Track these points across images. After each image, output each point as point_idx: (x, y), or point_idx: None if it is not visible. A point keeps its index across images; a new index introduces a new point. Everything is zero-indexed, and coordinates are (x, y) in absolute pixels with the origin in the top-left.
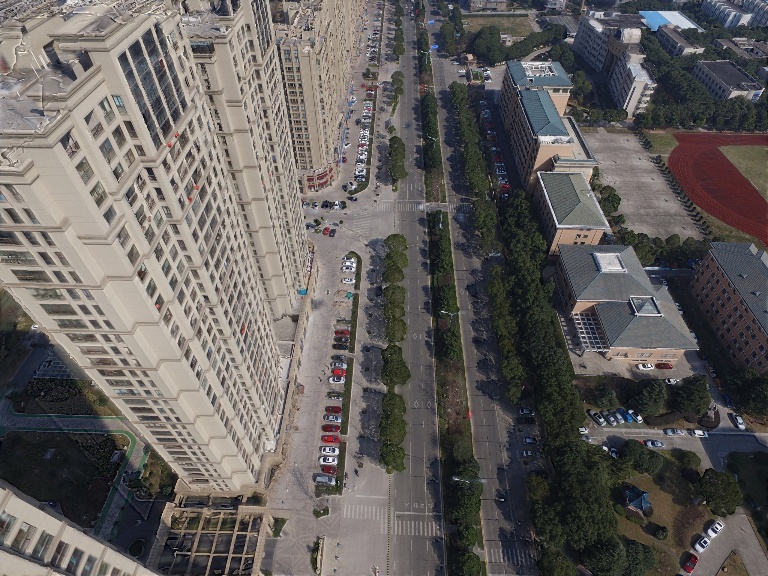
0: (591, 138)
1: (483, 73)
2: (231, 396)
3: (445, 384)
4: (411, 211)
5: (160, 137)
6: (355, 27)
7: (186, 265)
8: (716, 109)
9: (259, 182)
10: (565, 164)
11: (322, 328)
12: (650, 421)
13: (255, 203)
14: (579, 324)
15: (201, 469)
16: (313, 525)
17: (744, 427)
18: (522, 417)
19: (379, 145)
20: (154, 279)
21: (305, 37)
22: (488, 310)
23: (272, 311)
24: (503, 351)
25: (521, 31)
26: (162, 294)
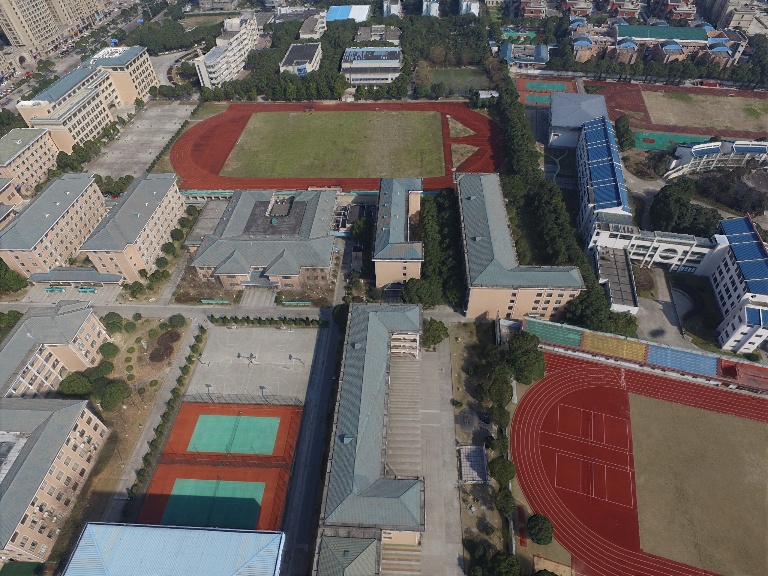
0: (158, 109)
1: None
2: None
3: None
4: None
5: None
6: None
7: None
8: (267, 82)
9: None
10: (36, 122)
11: None
12: None
13: None
14: None
15: None
16: None
17: None
18: None
19: None
20: None
21: None
22: None
23: None
24: None
25: None
26: None
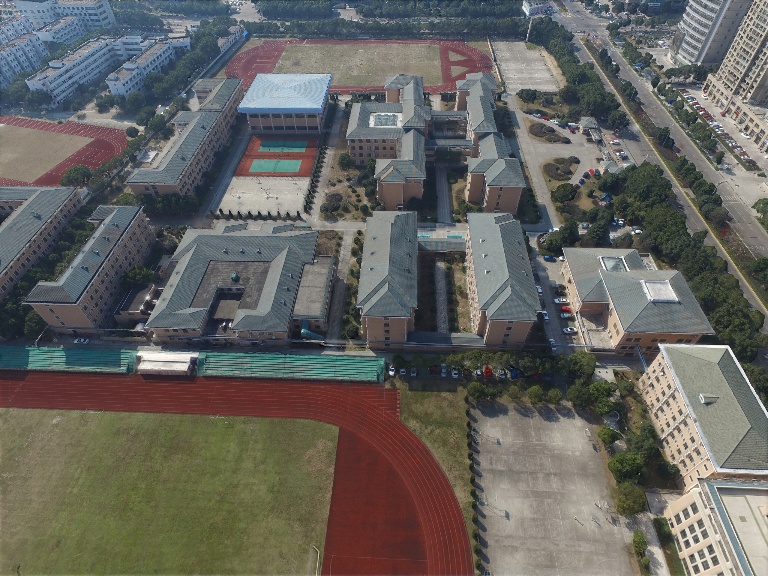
0: None
1: None
2: None
3: None
4: None
5: None
6: None
7: None
8: None
9: None
10: (763, 483)
11: None
12: None
13: None
14: None
15: None
16: None
17: None
18: None
19: None
20: None
21: None
22: None
23: None
24: None
25: None
26: None
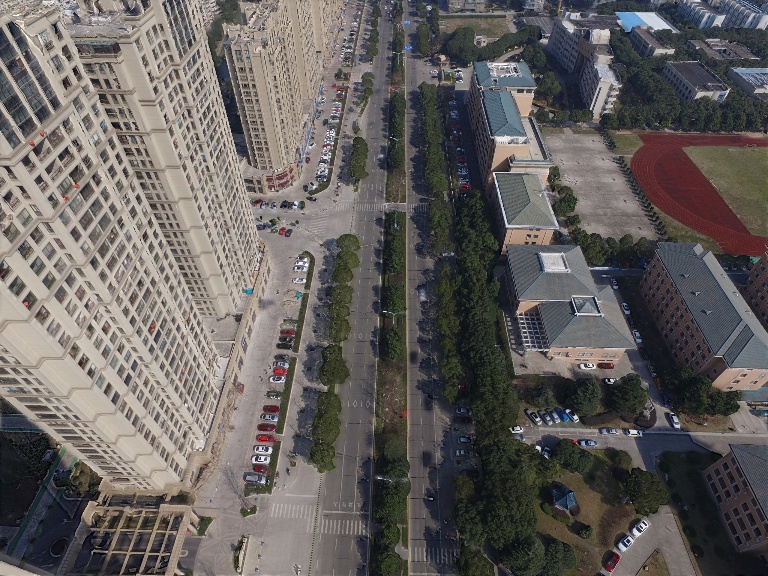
0: (556, 139)
1: (455, 74)
2: (141, 394)
3: (385, 383)
4: (369, 211)
5: (18, 135)
6: (330, 28)
7: (68, 263)
8: (682, 110)
9: (184, 181)
10: (521, 164)
11: (268, 328)
12: (586, 420)
13: (183, 202)
14: (523, 324)
15: (118, 467)
16: (239, 524)
17: (679, 426)
18: (459, 416)
19: (344, 145)
20: (21, 277)
21: (257, 37)
22: (436, 310)
23: (214, 310)
24: (444, 350)
25: (497, 32)
26: (34, 292)
